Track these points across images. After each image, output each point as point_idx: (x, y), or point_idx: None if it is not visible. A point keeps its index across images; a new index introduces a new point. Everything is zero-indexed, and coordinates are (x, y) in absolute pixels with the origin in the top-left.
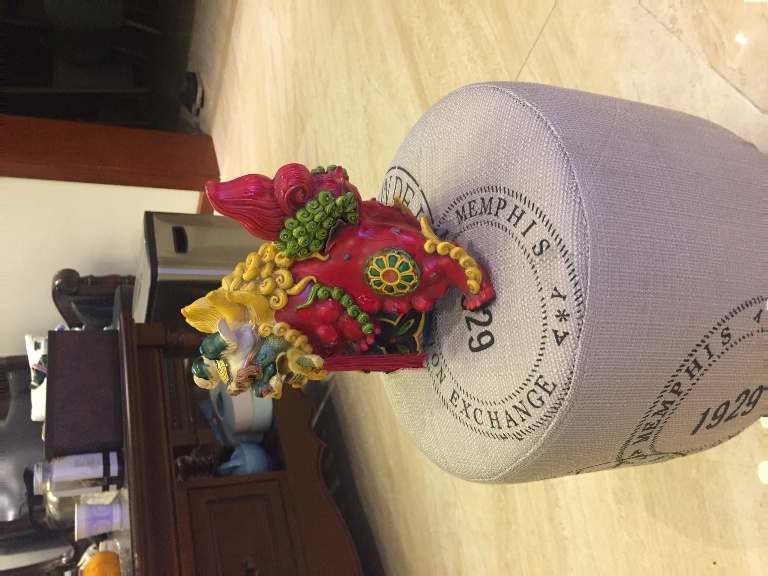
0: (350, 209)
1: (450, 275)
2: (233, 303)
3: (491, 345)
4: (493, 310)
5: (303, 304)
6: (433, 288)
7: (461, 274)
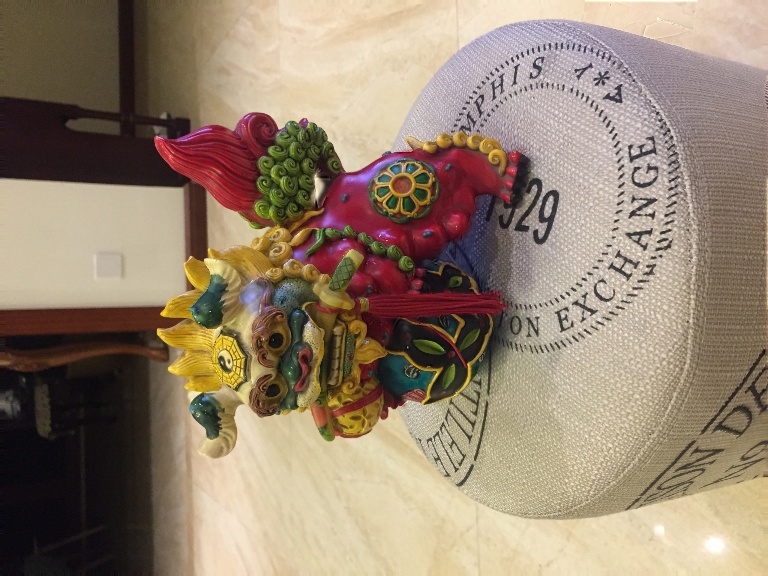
0: (327, 146)
1: (467, 168)
2: None
3: (558, 200)
4: (535, 172)
5: (313, 245)
6: (458, 196)
7: (478, 161)
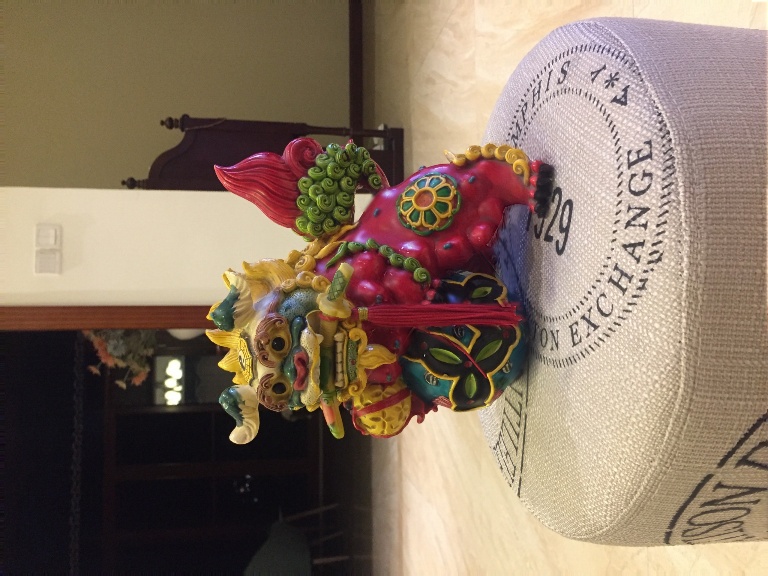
0: (366, 164)
1: (494, 179)
2: (254, 281)
3: (572, 209)
4: (557, 180)
5: (332, 258)
6: (484, 207)
7: (505, 171)
